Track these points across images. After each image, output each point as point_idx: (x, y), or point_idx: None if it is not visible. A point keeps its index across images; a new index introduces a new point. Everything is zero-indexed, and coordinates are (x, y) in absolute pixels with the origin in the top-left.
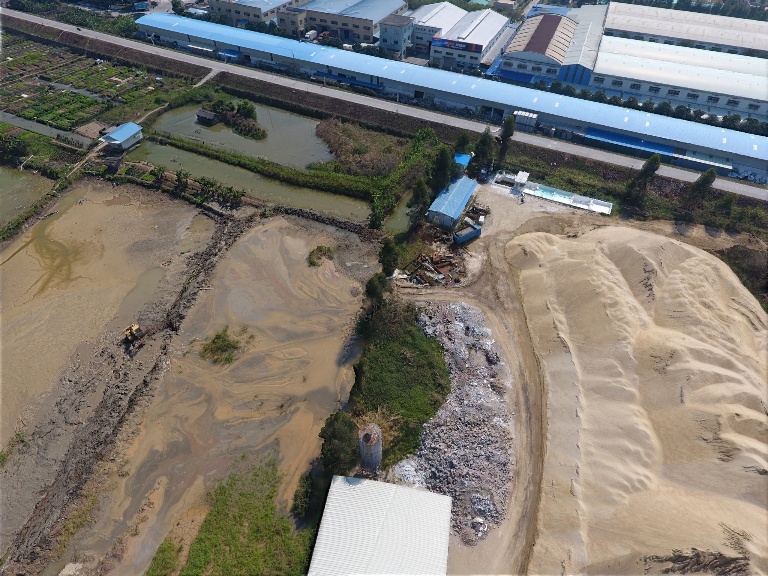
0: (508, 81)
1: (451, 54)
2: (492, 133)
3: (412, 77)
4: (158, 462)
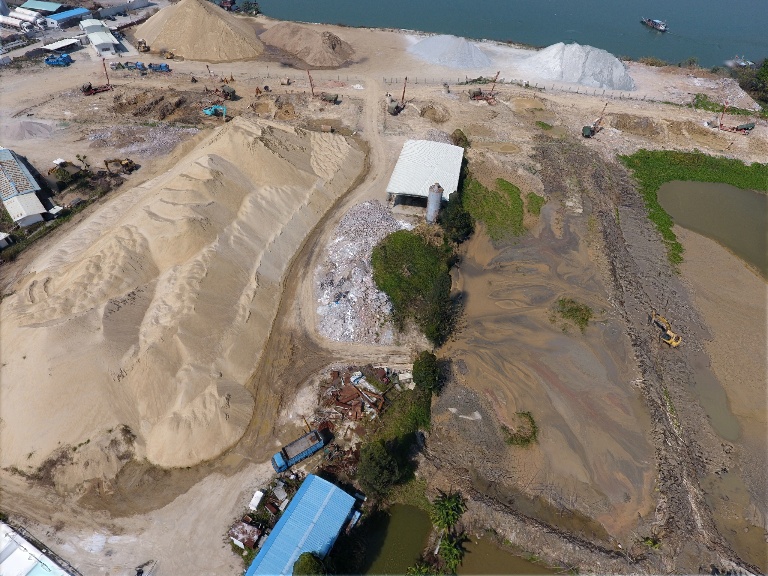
0: None
1: None
2: None
3: None
4: (568, 245)
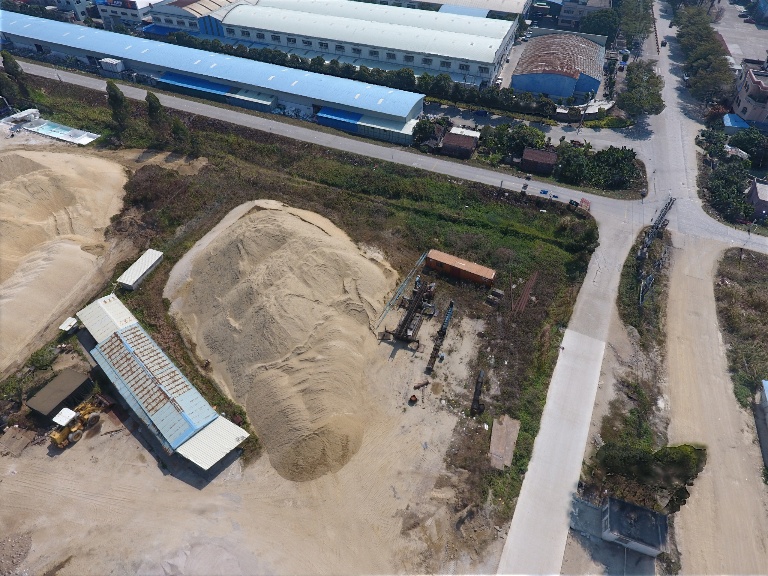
0: (157, 36)
1: (115, 12)
2: (1, 71)
3: (30, 30)
4: None
